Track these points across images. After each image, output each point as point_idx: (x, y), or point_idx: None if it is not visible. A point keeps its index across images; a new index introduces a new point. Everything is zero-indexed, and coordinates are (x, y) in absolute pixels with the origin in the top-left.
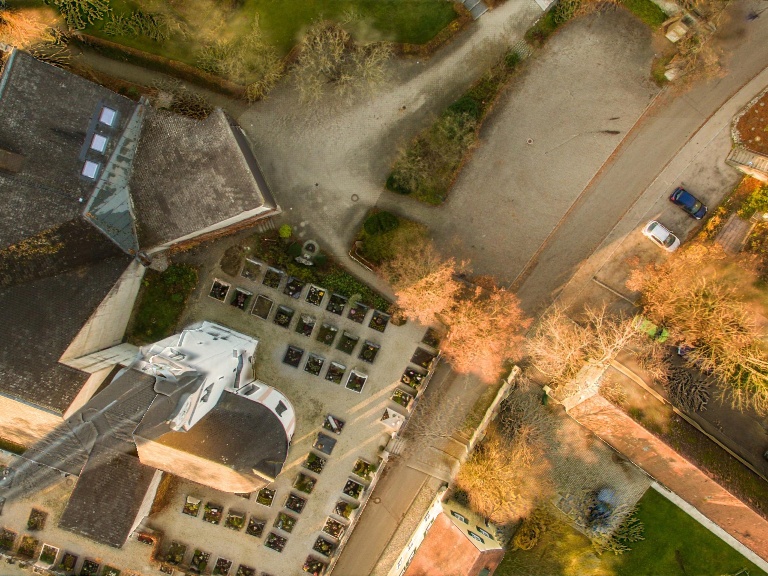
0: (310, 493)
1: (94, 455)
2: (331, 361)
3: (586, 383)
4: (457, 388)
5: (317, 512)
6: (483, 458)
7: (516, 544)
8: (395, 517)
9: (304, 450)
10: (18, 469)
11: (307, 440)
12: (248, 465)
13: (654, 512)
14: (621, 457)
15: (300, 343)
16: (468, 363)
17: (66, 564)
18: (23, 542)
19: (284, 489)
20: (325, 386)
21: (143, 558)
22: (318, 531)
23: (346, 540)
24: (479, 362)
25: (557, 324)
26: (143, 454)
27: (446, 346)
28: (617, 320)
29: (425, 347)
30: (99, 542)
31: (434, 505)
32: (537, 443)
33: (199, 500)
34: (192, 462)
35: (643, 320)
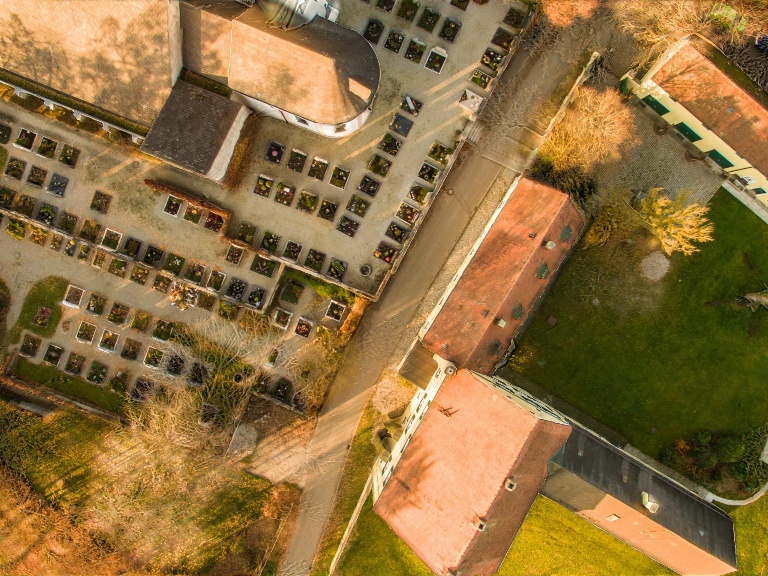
0: (385, 176)
1: (177, 89)
2: (411, 38)
3: (675, 37)
4: (535, 76)
5: (391, 197)
6: (561, 142)
7: (587, 240)
8: (467, 210)
9: (380, 131)
10: (83, 149)
11: (384, 121)
12: (346, 71)
13: (724, 212)
14: (694, 155)
15: (381, 19)
16: (547, 50)
17: (129, 250)
18: (85, 226)
19: (358, 171)
20: (404, 65)
21: (209, 247)
22: (391, 217)
23: (421, 221)
24: (558, 49)
25: (640, 1)
26: (234, 69)
27: (526, 30)
28: (697, 7)
29: (506, 27)
30: (183, 167)
31: (511, 187)
32: (612, 138)
33: (272, 179)
34: (288, 66)
35: (723, 6)
